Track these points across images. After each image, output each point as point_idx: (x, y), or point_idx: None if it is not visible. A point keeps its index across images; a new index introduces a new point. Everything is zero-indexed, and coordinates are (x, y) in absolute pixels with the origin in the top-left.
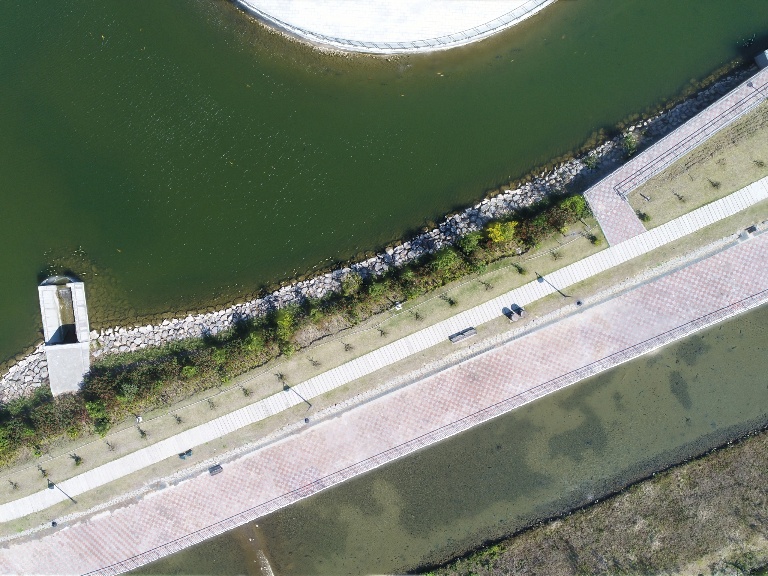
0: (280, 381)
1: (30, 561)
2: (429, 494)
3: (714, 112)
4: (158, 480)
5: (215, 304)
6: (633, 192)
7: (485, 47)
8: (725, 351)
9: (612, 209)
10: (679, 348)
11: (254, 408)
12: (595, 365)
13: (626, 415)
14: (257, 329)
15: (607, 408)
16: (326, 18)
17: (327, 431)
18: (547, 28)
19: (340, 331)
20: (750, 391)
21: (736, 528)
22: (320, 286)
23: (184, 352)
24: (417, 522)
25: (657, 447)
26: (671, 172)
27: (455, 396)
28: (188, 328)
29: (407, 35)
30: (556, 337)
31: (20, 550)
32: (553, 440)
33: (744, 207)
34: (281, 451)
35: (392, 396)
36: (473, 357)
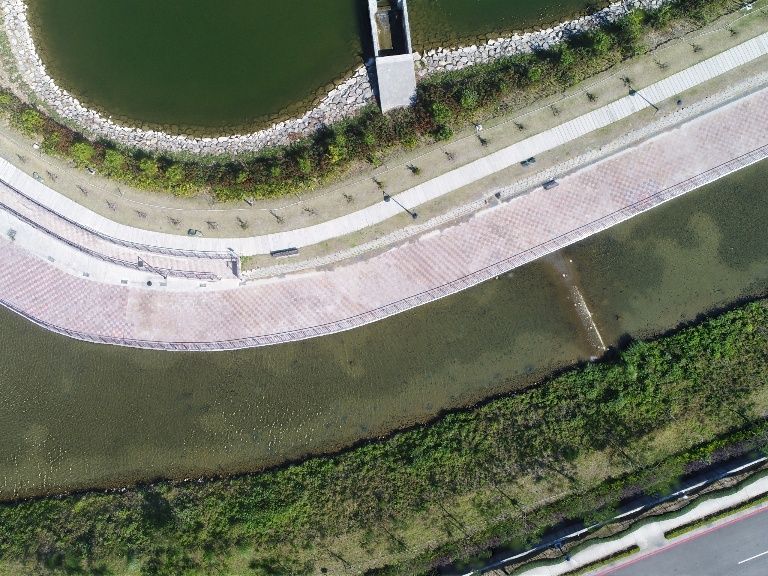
0: (626, 85)
1: (356, 284)
2: (749, 225)
3: None
4: (498, 190)
5: (540, 24)
6: None
7: None
8: None
9: None
10: None
11: (598, 114)
12: None
13: None
14: None
15: None
16: None
17: (666, 143)
18: None
19: (688, 33)
20: None
21: None
22: None
23: None
24: (736, 254)
25: None
26: None
27: None
28: (516, 46)
29: None
30: None
31: (345, 273)
32: None
33: None
34: (618, 164)
35: (734, 105)
36: None
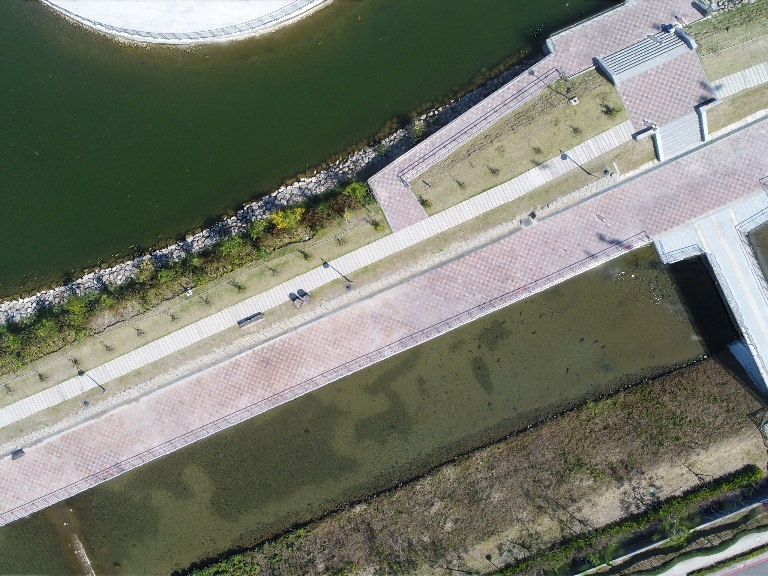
0: (74, 366)
1: None
2: (239, 478)
3: (496, 100)
4: None
5: (21, 291)
6: (416, 179)
7: (281, 38)
8: (525, 336)
9: (395, 196)
10: (481, 333)
11: (50, 393)
12: (385, 349)
13: (430, 399)
14: (57, 315)
15: (411, 393)
16: (114, 9)
17: (126, 415)
18: (342, 19)
19: (133, 317)
20: (550, 375)
21: (524, 509)
22: (121, 273)
23: None
24: (227, 506)
25: (460, 431)
26: (453, 159)
27: (249, 380)
28: None
29: (193, 26)
30: (347, 322)
31: None
32: (359, 424)
33: (522, 193)
34: (81, 435)
35: (188, 381)
36: (267, 342)
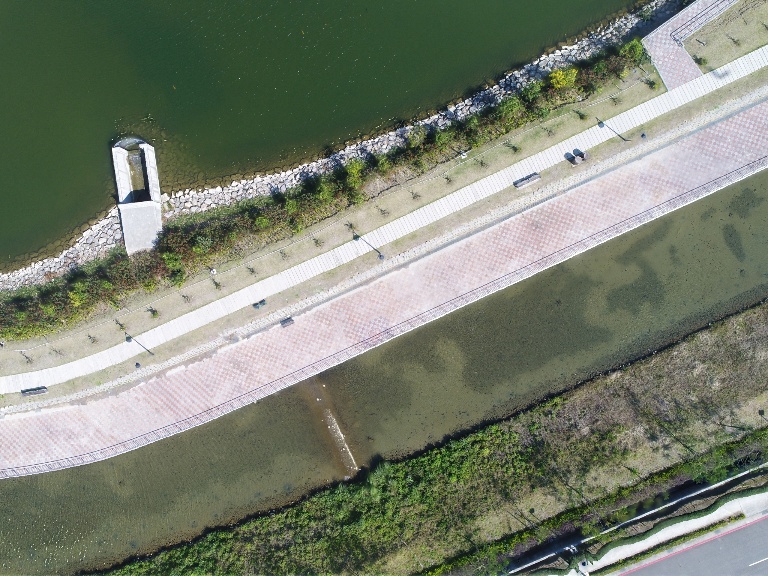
0: (350, 230)
1: (107, 417)
2: (491, 350)
3: None
4: (233, 331)
5: (282, 165)
6: (689, 38)
7: None
8: None
9: (669, 55)
10: (732, 201)
11: (325, 258)
12: (654, 210)
13: (682, 268)
14: None
15: (663, 262)
16: None
17: (395, 282)
18: None
19: (407, 181)
20: None
21: None
22: (385, 143)
23: (254, 210)
24: (480, 378)
25: (712, 298)
26: (725, 18)
27: (519, 244)
28: (257, 188)
29: None
30: (616, 184)
31: (97, 406)
32: (611, 294)
33: None
34: (350, 302)
35: (457, 246)
36: (536, 206)
